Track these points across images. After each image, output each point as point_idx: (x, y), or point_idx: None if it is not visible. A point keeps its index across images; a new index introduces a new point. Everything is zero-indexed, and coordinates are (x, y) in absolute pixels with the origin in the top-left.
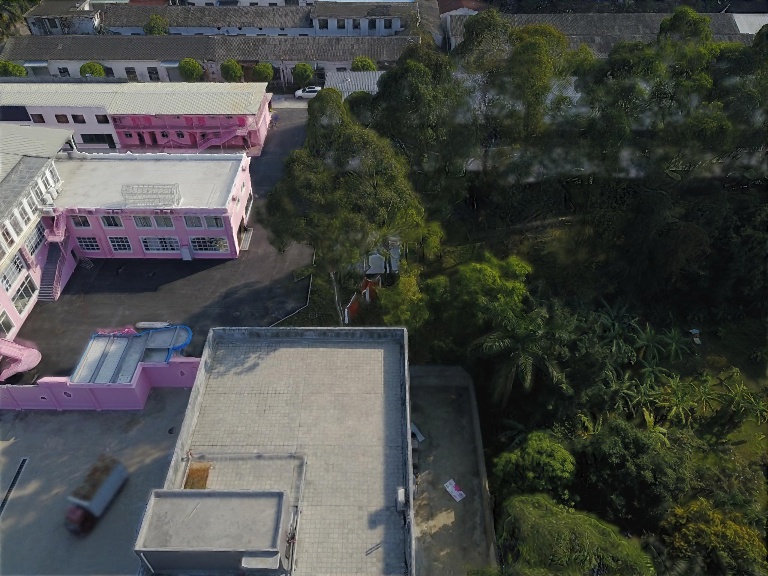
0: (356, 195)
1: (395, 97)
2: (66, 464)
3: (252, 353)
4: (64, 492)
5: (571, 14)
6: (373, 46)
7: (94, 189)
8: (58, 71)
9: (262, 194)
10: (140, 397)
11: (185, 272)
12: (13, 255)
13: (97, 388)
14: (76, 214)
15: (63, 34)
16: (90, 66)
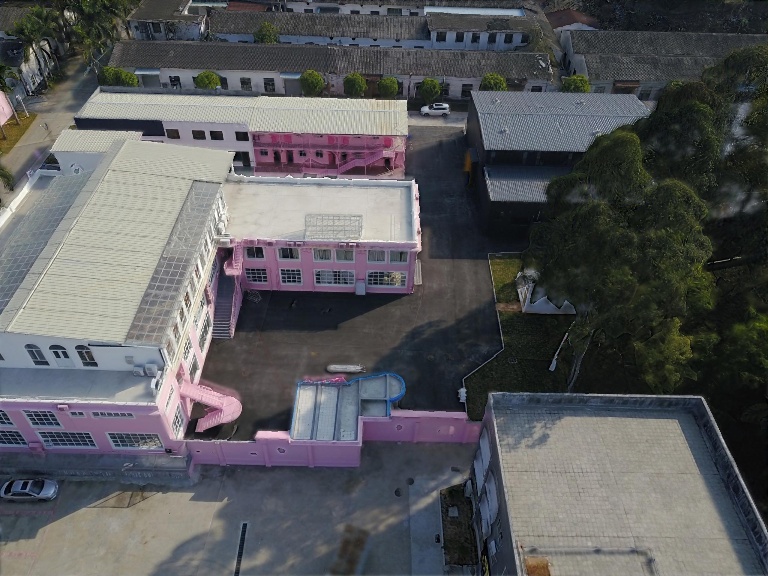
0: (671, 254)
1: (682, 141)
2: (292, 530)
3: (536, 422)
4: (300, 564)
5: (694, 33)
6: (500, 62)
7: (264, 217)
8: (169, 79)
9: (420, 221)
10: (359, 454)
11: (361, 308)
12: (202, 292)
13: (321, 446)
14: (253, 245)
15: (167, 39)
16: (207, 76)
